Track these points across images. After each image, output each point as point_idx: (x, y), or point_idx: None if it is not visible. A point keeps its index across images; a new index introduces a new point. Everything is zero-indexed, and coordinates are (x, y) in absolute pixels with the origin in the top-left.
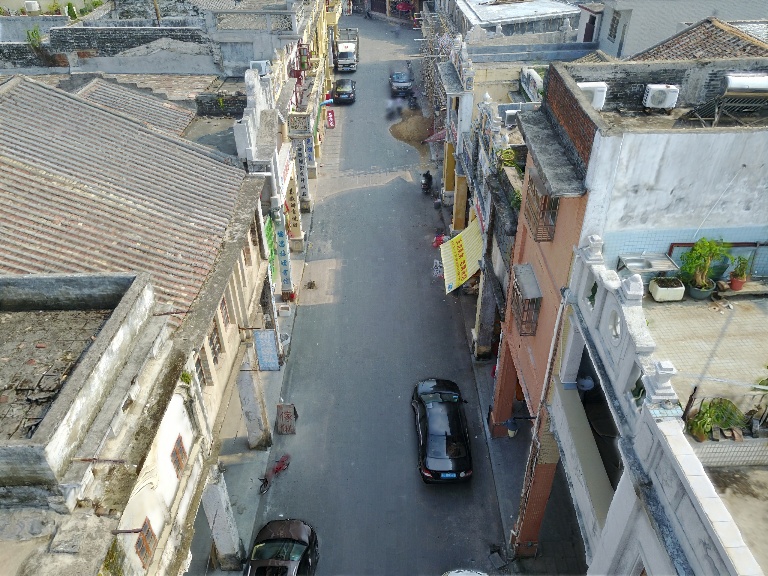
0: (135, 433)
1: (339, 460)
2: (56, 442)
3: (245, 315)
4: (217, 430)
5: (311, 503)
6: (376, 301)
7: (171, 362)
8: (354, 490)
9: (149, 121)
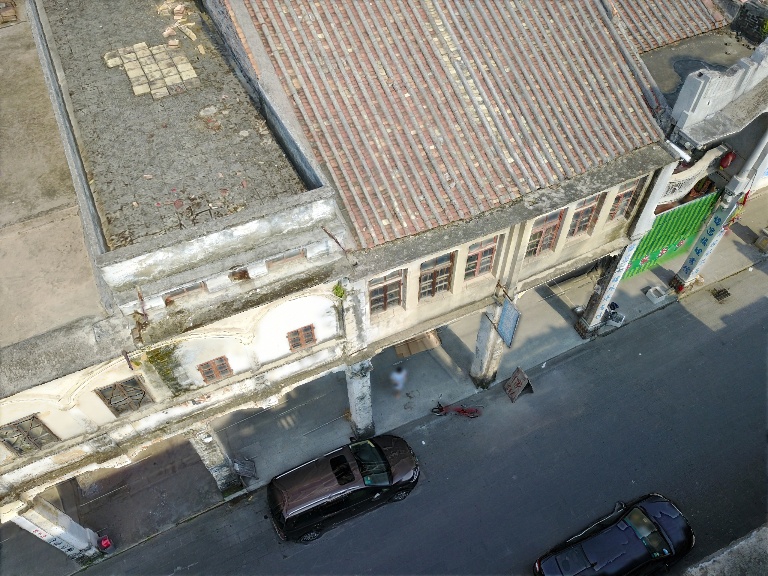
0: (224, 302)
1: (510, 461)
2: (119, 269)
3: (511, 277)
4: (381, 344)
5: (449, 462)
6: (761, 377)
7: (315, 273)
8: (486, 495)
9: (652, 8)
